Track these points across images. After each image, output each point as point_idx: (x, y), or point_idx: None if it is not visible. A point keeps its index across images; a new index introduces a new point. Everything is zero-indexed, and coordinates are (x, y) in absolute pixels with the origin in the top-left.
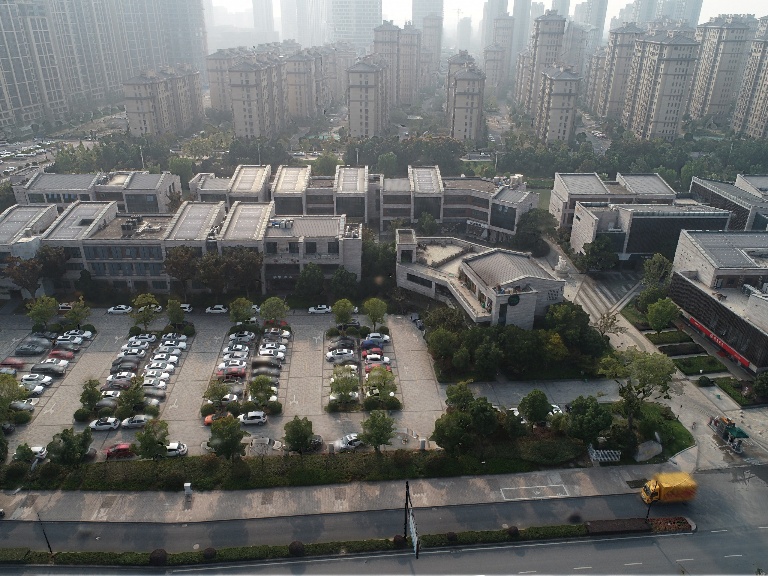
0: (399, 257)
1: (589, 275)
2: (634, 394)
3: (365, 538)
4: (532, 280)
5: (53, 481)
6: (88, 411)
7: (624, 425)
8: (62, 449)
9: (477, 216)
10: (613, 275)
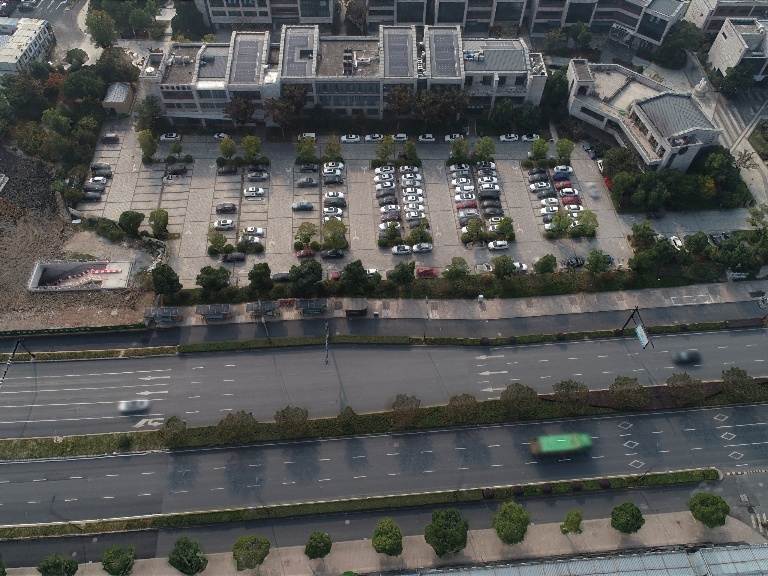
0: (576, 91)
1: (723, 94)
2: (767, 236)
3: (596, 329)
4: (698, 131)
5: (394, 293)
6: (387, 240)
7: (751, 252)
8: (402, 276)
9: (624, 20)
10: (743, 94)
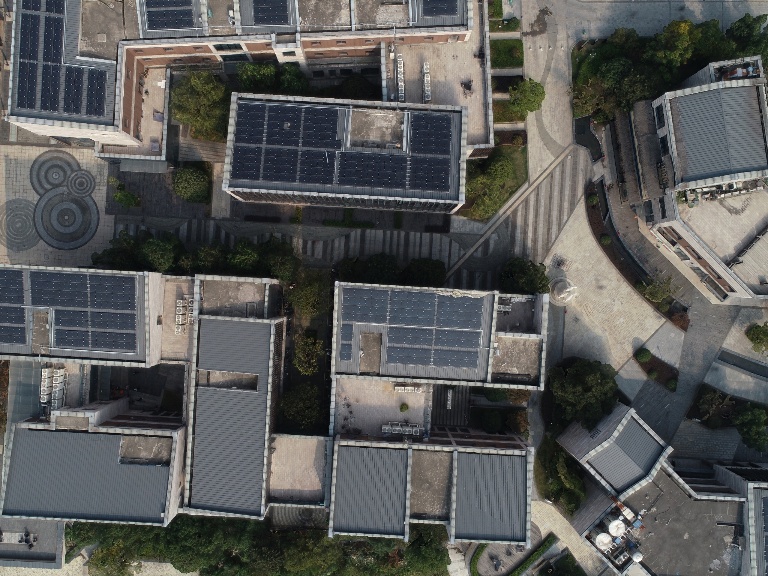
0: None
1: None
2: None
3: None
4: None
5: None
6: None
7: None
8: None
9: None
10: (488, 287)
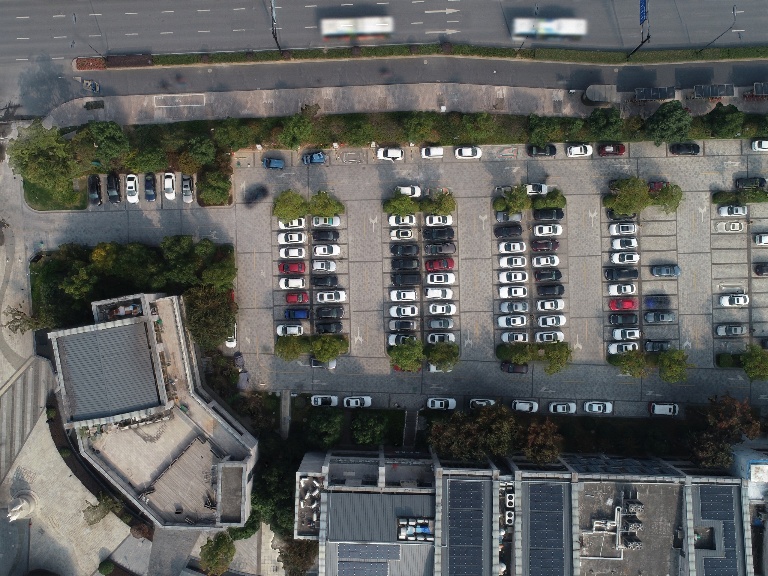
0: None
1: None
2: None
3: (310, 64)
4: None
5: None
6: None
7: None
8: (546, 121)
9: None
10: None
